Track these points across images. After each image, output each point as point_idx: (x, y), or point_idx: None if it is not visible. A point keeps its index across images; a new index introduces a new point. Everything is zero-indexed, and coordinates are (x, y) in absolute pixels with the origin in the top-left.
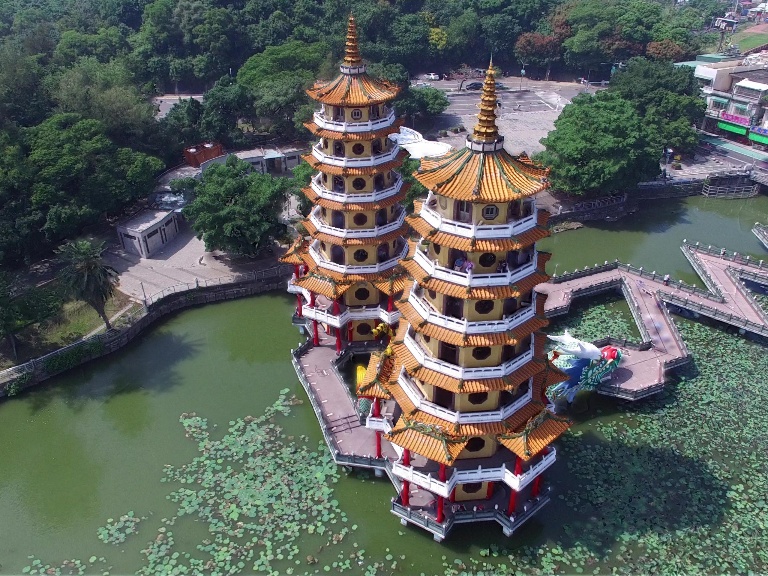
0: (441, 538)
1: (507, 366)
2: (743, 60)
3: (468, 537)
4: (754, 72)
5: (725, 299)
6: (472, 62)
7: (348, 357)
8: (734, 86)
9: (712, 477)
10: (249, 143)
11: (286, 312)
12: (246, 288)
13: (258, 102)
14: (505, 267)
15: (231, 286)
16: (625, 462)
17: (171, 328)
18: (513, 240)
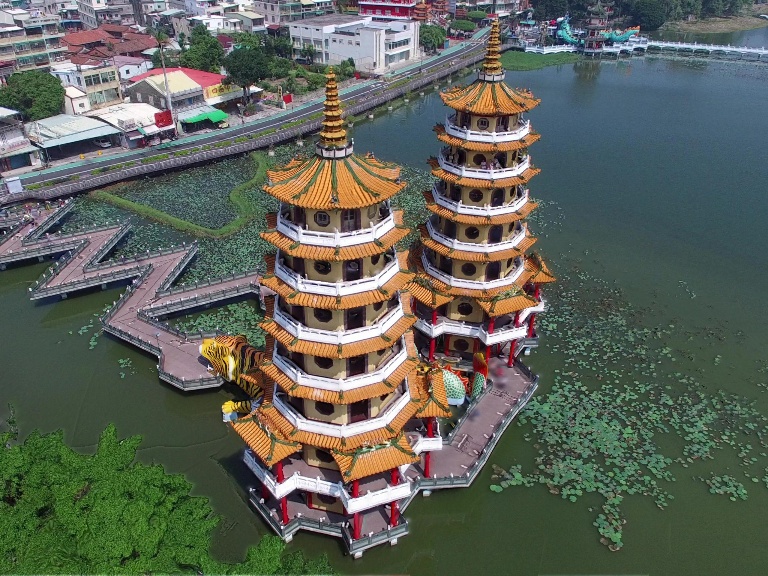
0: None
1: None
2: None
3: None
4: None
5: None
6: None
7: None
8: None
9: None
10: None
11: None
12: None
13: None
14: None
15: None
16: None
17: None
18: None
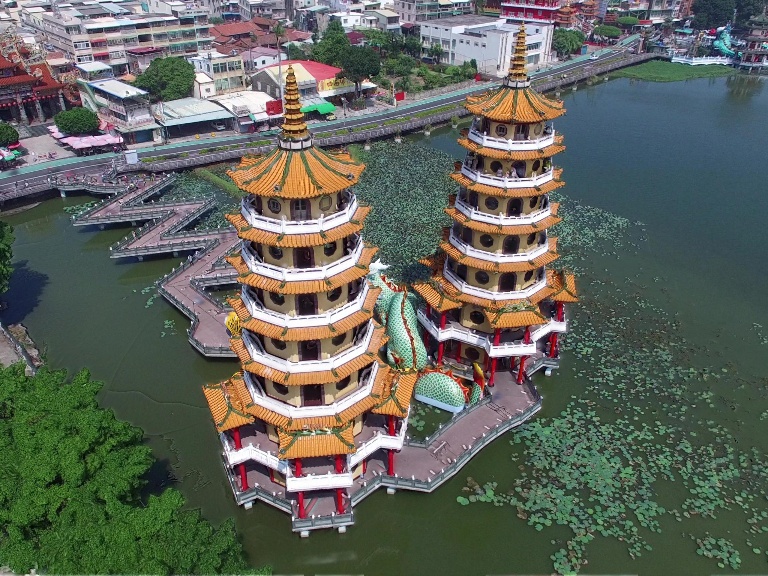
0: None
1: None
2: None
3: None
4: None
5: None
6: None
7: None
8: None
9: (415, 265)
10: None
11: None
12: None
13: None
14: None
15: None
16: None
17: None
18: None
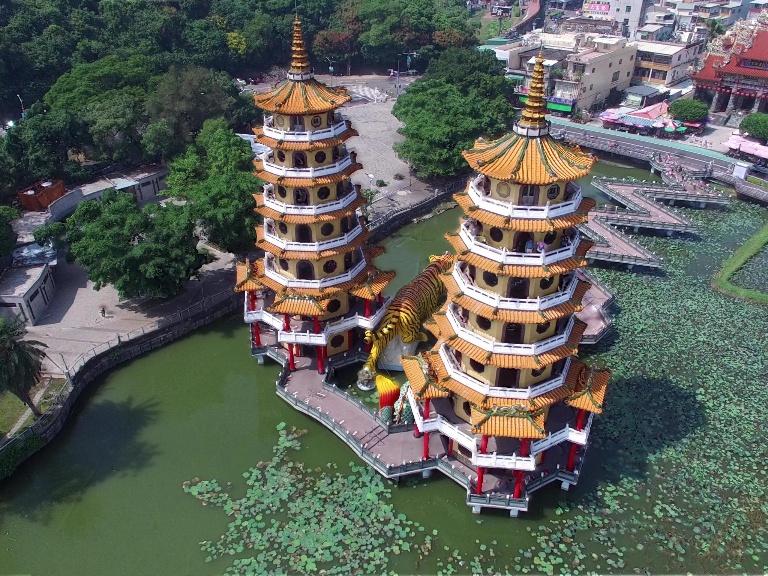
0: (517, 513)
1: (566, 333)
2: (522, 41)
3: (538, 503)
4: (535, 51)
5: (608, 243)
6: (273, 64)
7: (330, 373)
8: (526, 64)
9: (680, 389)
10: (90, 175)
11: (227, 346)
12: (173, 332)
13: (94, 127)
14: (567, 241)
15: (156, 333)
16: (614, 397)
17: (106, 396)
18: (579, 214)
